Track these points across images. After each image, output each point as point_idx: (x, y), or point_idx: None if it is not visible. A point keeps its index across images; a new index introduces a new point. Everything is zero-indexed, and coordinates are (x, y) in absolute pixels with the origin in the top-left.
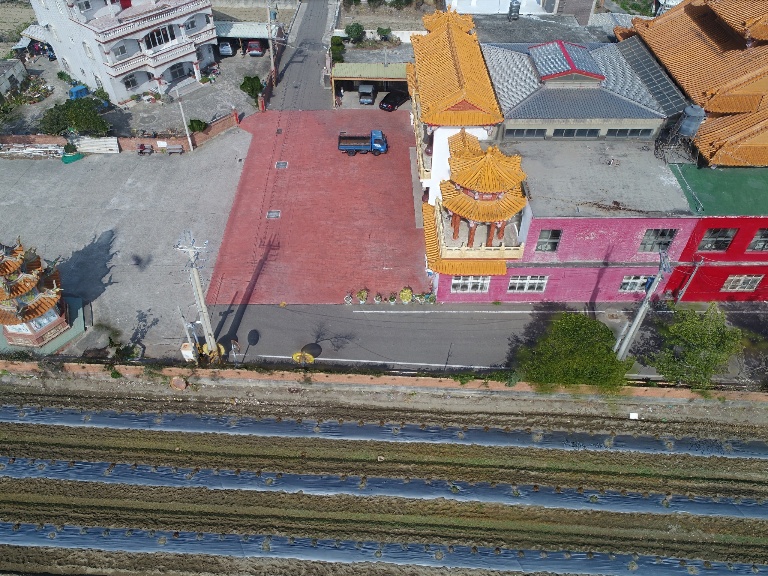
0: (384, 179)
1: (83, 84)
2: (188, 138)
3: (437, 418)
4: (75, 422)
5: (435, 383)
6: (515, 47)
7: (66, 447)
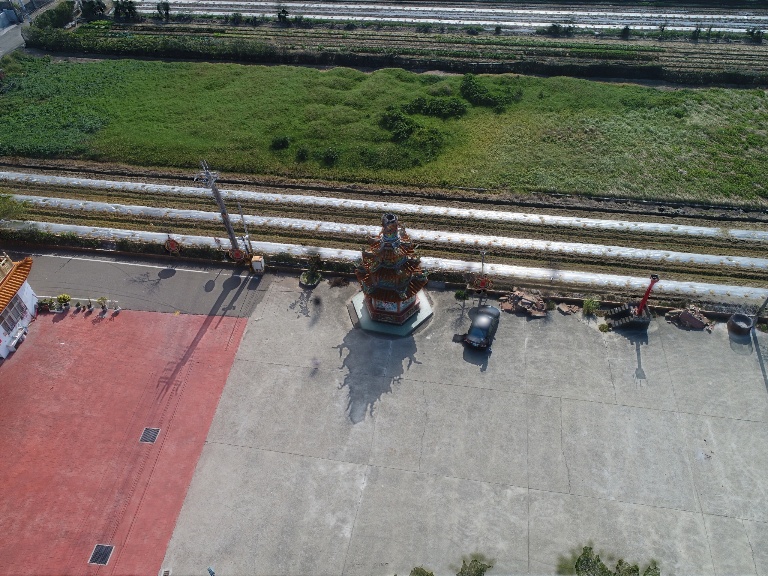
0: None
1: None
2: None
3: None
4: (347, 251)
5: None
6: None
7: (350, 239)
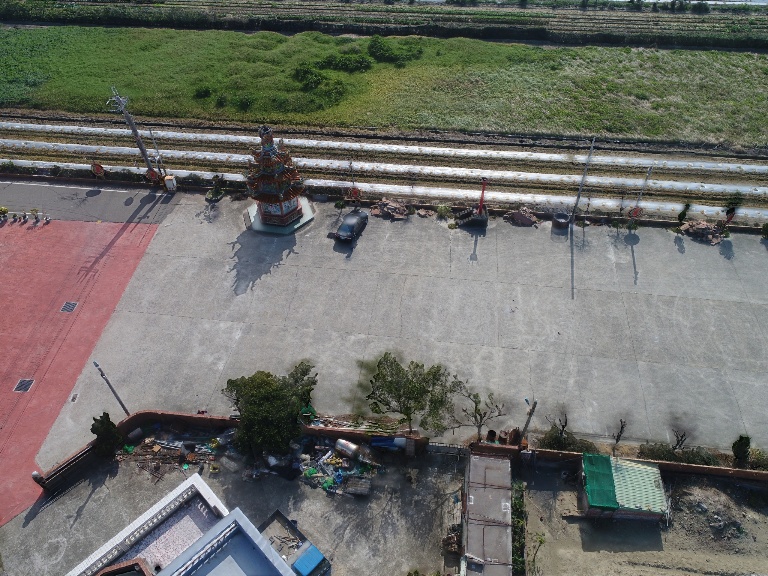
0: None
1: None
2: None
3: None
4: None
5: None
6: None
7: None
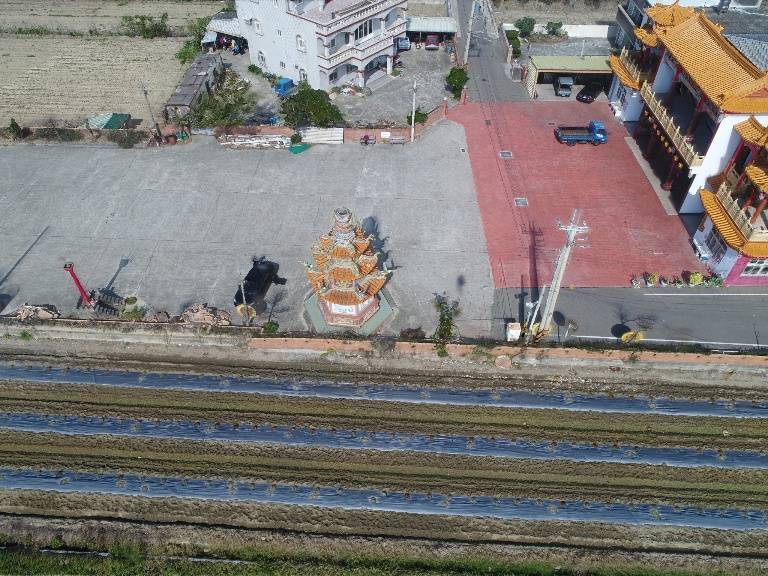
0: (614, 168)
1: (279, 77)
2: (412, 129)
3: (764, 395)
4: (416, 399)
5: (759, 361)
6: (762, 38)
7: (418, 422)
